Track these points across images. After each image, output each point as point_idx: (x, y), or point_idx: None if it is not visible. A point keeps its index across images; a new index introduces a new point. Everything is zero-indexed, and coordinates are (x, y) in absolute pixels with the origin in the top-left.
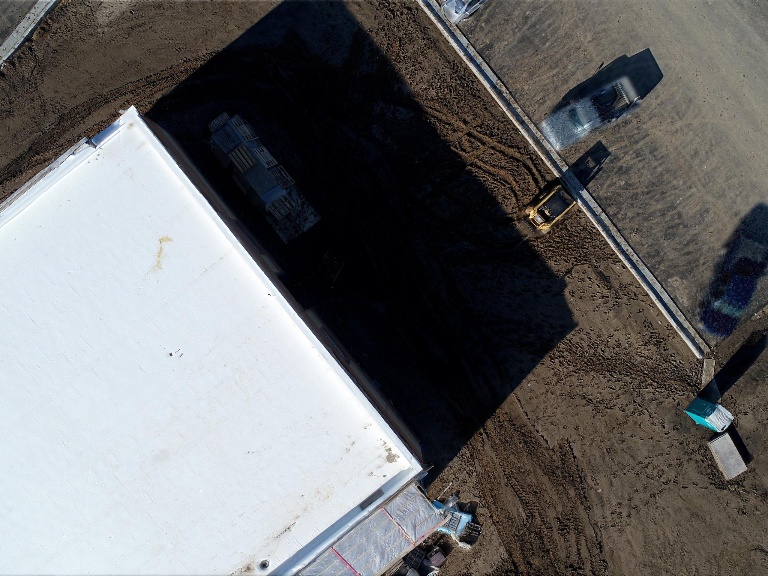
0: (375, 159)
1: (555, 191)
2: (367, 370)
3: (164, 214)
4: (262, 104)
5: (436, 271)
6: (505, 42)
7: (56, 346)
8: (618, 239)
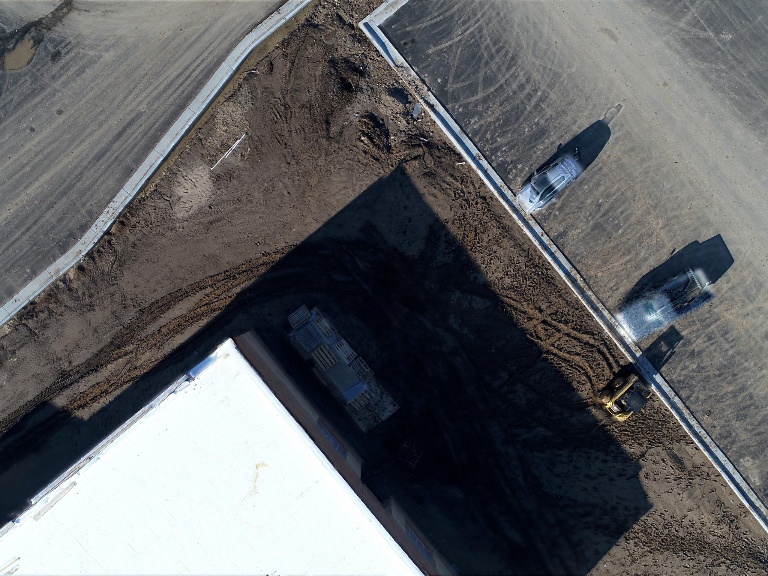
0: (453, 349)
1: (632, 383)
2: (446, 554)
3: (260, 440)
4: (341, 296)
5: (513, 457)
6: (579, 230)
7: (154, 571)
8: (691, 422)
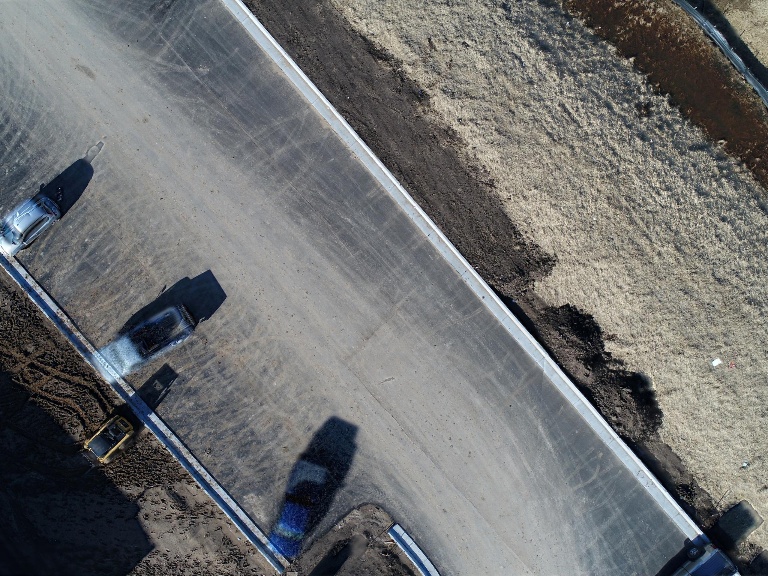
0: None
1: (106, 425)
2: None
3: None
4: None
5: (5, 503)
6: (65, 270)
7: None
8: (190, 460)
